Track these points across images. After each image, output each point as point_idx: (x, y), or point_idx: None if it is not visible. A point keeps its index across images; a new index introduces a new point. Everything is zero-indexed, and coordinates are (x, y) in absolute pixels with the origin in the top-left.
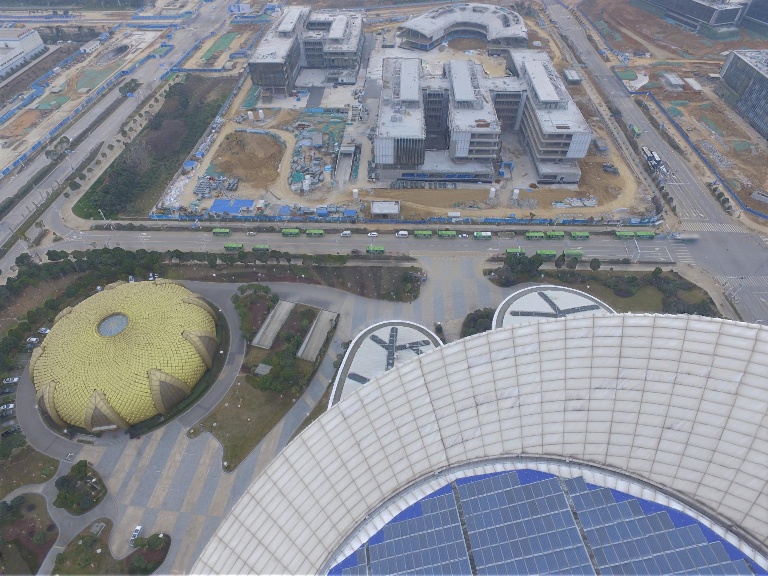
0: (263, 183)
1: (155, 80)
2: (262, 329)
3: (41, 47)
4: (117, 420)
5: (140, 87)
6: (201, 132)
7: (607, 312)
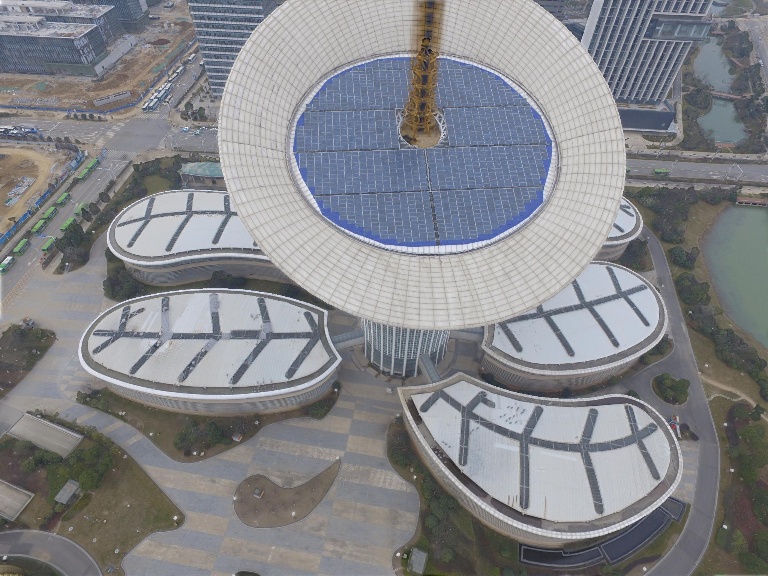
0: None
1: None
2: None
3: None
4: None
5: None
6: None
7: (160, 195)
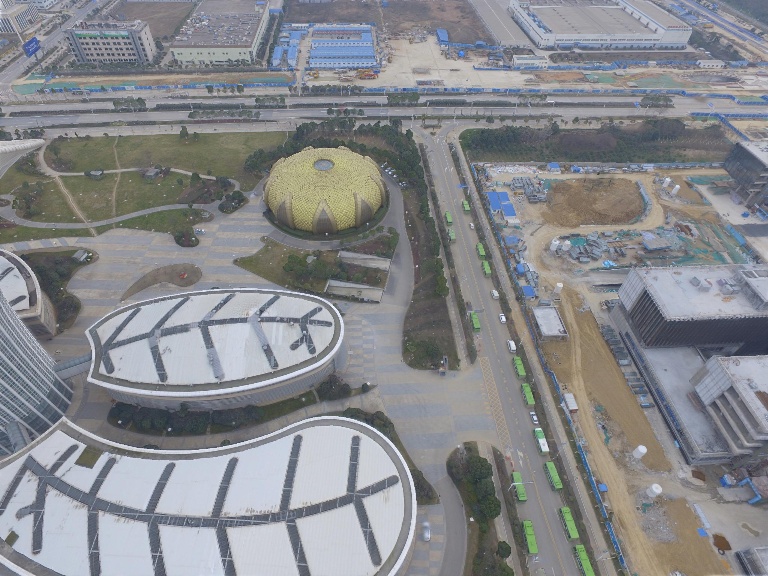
0: (552, 218)
1: (688, 112)
2: (357, 255)
3: (680, 45)
4: (265, 196)
5: (666, 108)
6: (610, 159)
7: None
